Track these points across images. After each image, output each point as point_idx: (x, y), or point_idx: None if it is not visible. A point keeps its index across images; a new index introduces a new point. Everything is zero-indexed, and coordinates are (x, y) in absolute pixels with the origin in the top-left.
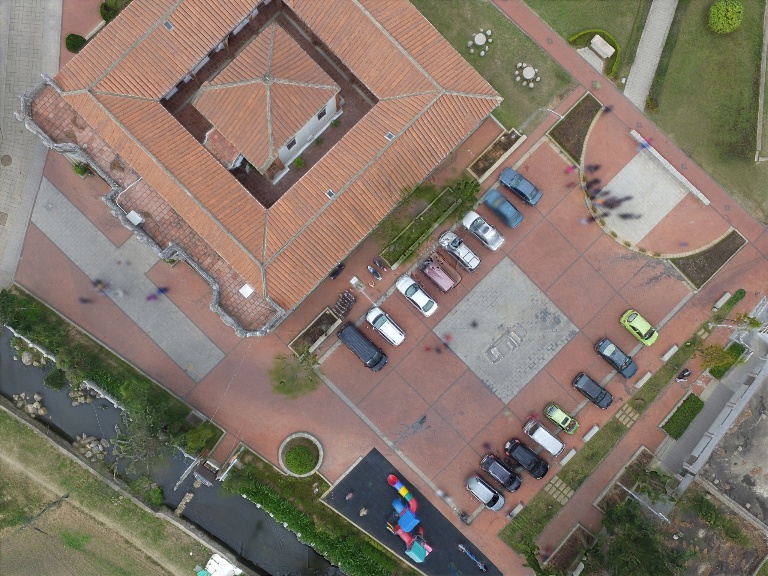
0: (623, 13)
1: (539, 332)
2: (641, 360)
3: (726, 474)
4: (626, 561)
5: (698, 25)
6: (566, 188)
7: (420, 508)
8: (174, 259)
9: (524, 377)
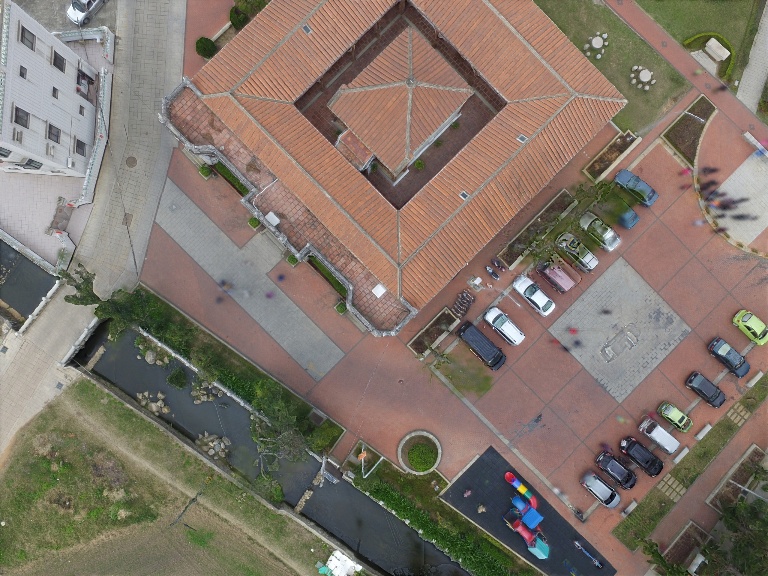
0: (736, 16)
1: (652, 332)
2: (752, 359)
3: None
4: (759, 557)
5: None
6: (679, 189)
7: None
8: None
9: (638, 376)
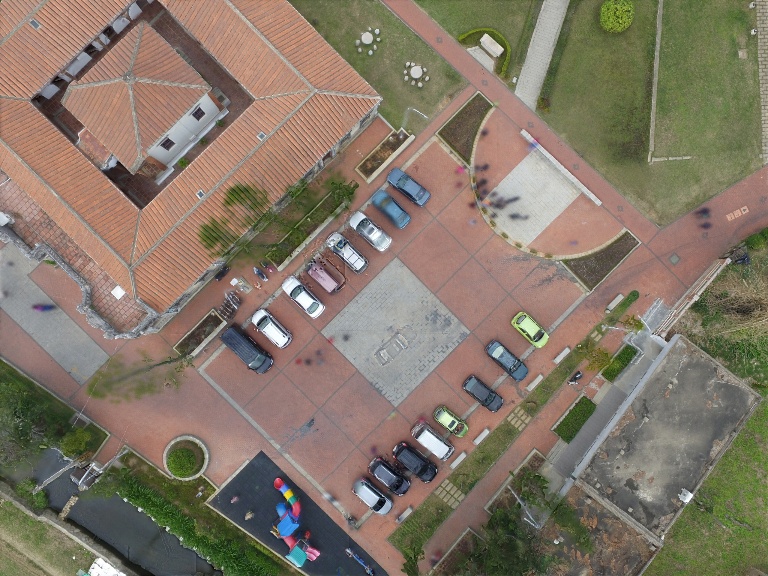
0: (514, 12)
1: (429, 334)
2: (533, 362)
3: (608, 478)
4: (495, 566)
5: (590, 24)
6: (456, 189)
7: (308, 512)
8: (51, 260)
9: (414, 379)
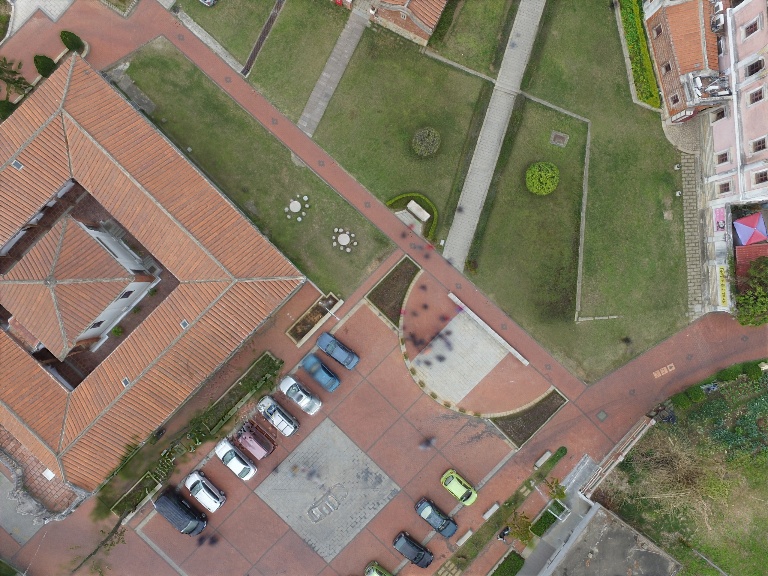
0: (441, 175)
1: (361, 491)
2: (463, 517)
3: None
4: None
5: (517, 186)
6: (386, 350)
7: None
8: None
9: (346, 536)
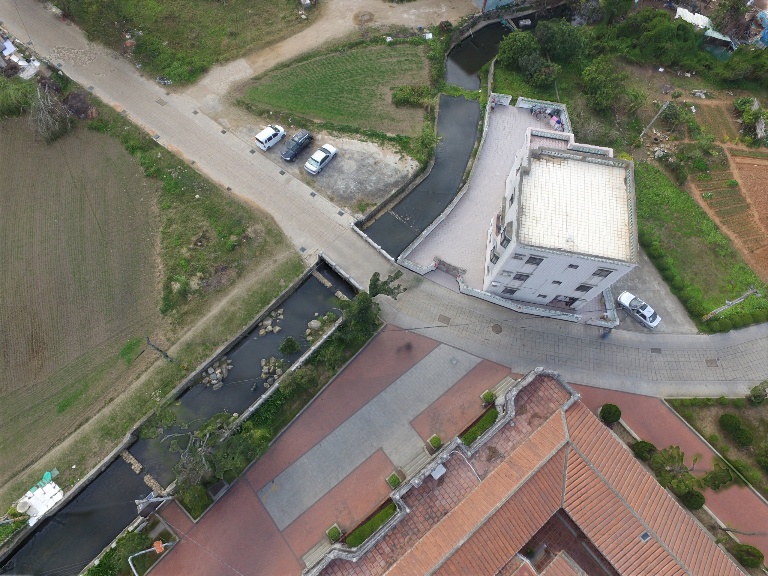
0: None
1: None
2: None
3: None
4: None
5: None
6: None
7: None
8: None
9: None
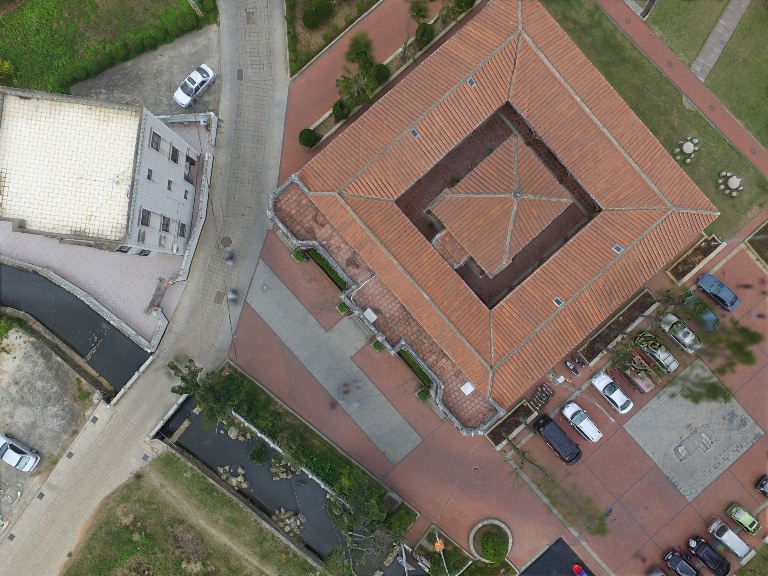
0: None
1: (726, 433)
2: None
3: None
4: None
5: None
6: (760, 295)
7: None
8: None
9: (709, 476)
